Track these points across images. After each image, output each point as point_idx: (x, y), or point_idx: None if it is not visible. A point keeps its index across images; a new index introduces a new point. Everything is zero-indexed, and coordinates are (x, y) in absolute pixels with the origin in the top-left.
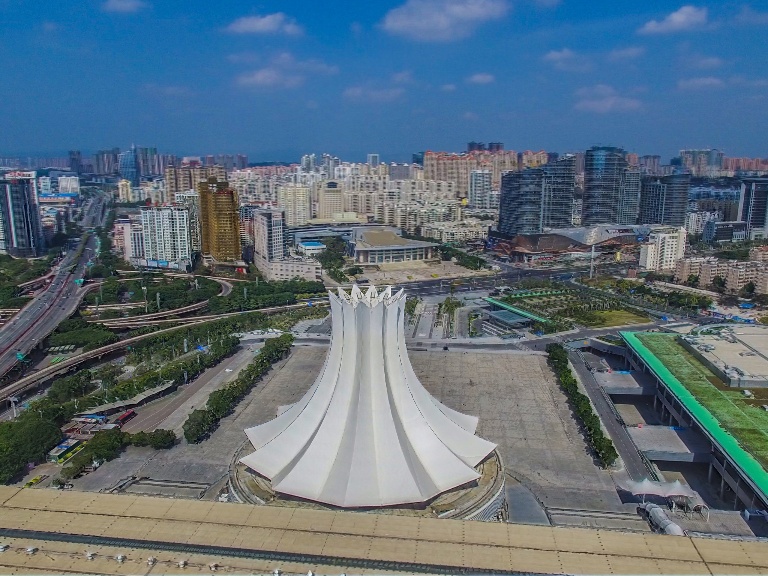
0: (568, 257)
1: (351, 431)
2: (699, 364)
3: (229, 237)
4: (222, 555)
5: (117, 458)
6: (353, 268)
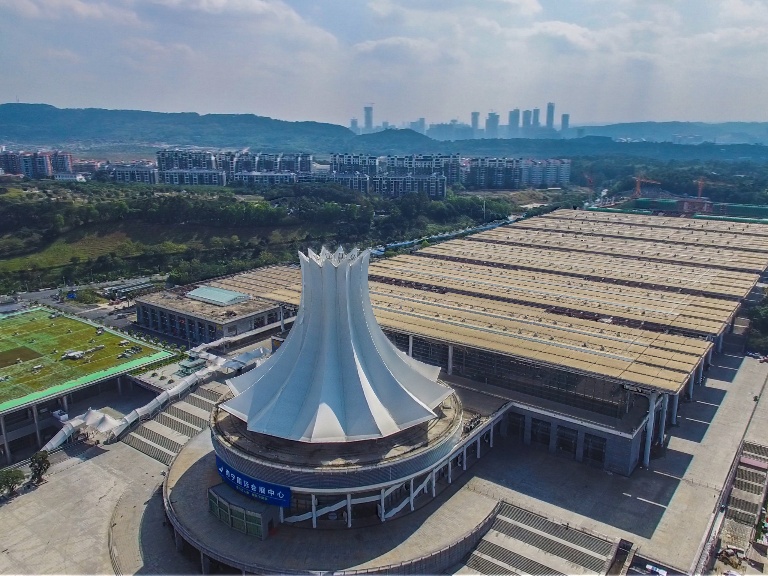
0: None
1: None
2: None
3: None
4: None
5: None
6: None
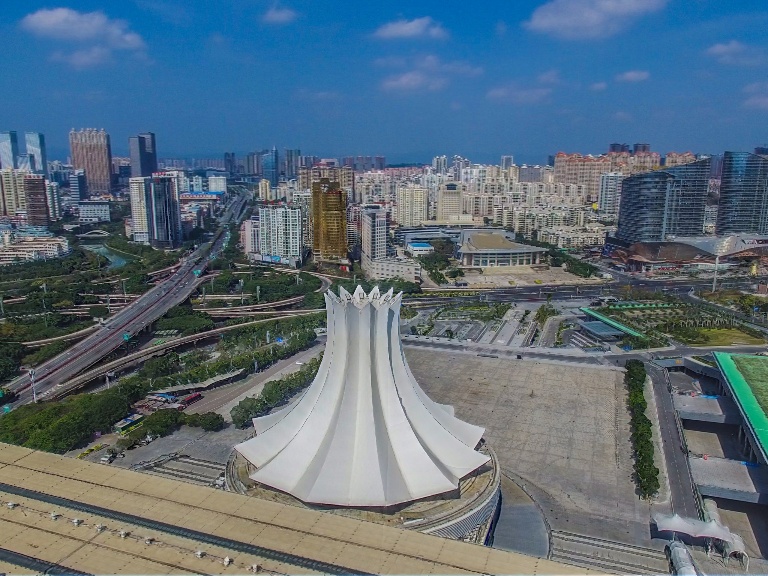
0: (694, 268)
1: (333, 429)
2: None
3: (335, 236)
4: (163, 531)
5: (170, 435)
6: (454, 270)
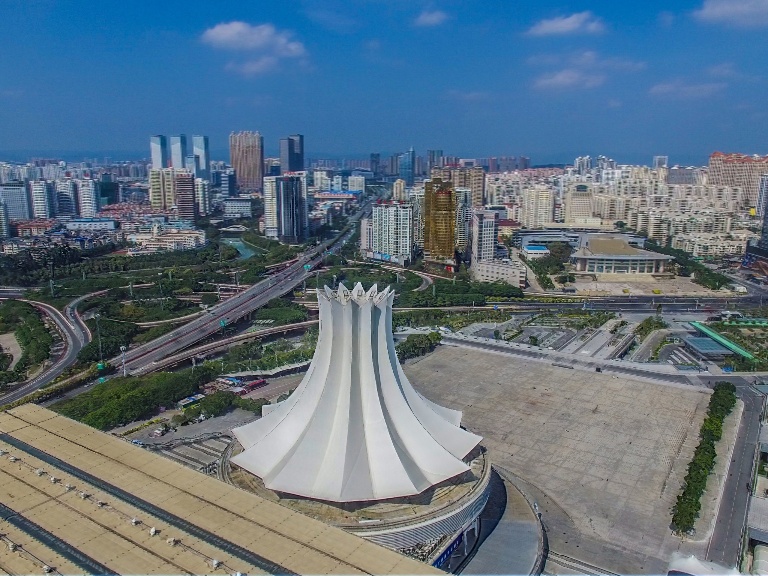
0: None
1: (311, 421)
2: None
3: (443, 236)
4: (118, 497)
5: (222, 416)
6: (564, 276)
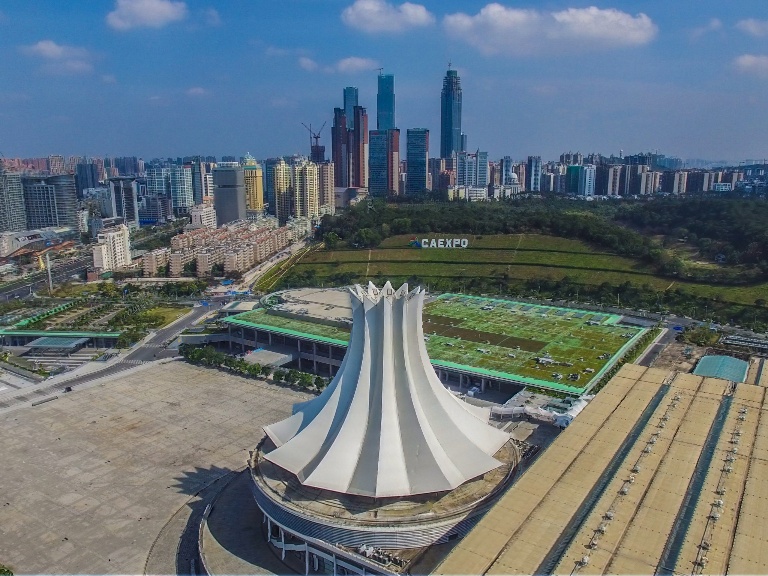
0: None
1: (438, 415)
2: (314, 324)
3: None
4: (591, 512)
5: None
6: None
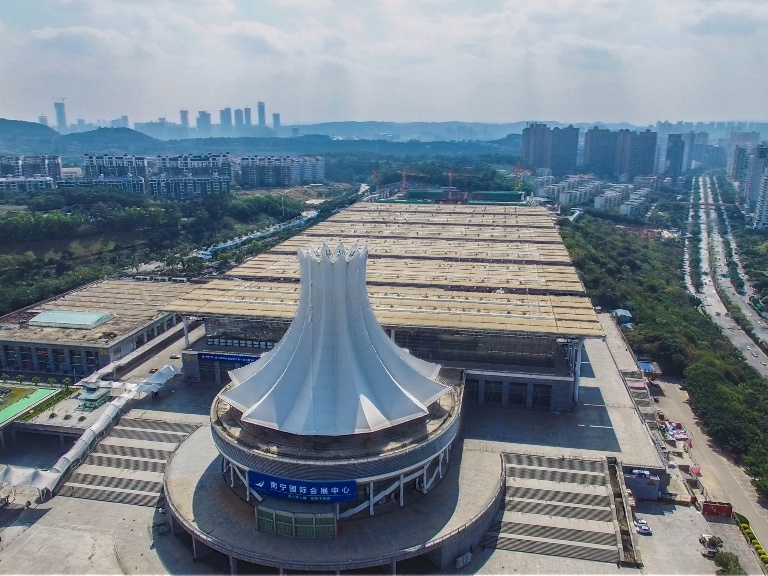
0: None
1: None
2: None
3: None
4: None
5: None
6: None
